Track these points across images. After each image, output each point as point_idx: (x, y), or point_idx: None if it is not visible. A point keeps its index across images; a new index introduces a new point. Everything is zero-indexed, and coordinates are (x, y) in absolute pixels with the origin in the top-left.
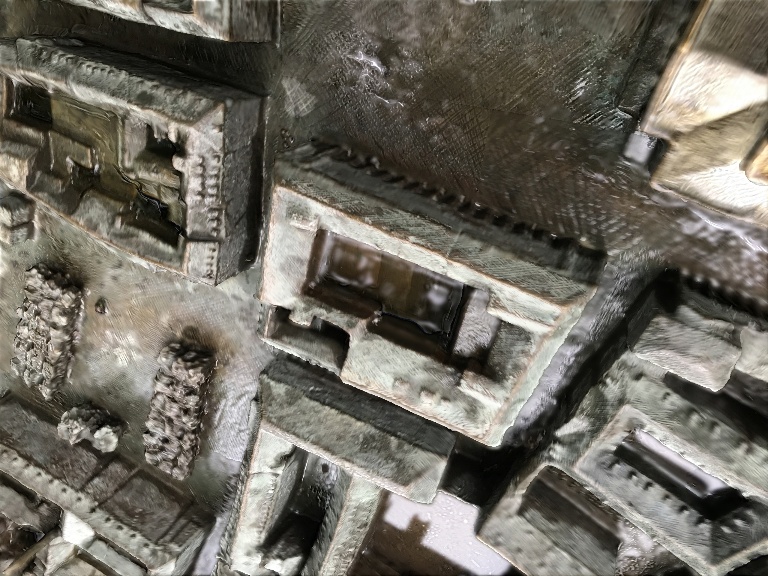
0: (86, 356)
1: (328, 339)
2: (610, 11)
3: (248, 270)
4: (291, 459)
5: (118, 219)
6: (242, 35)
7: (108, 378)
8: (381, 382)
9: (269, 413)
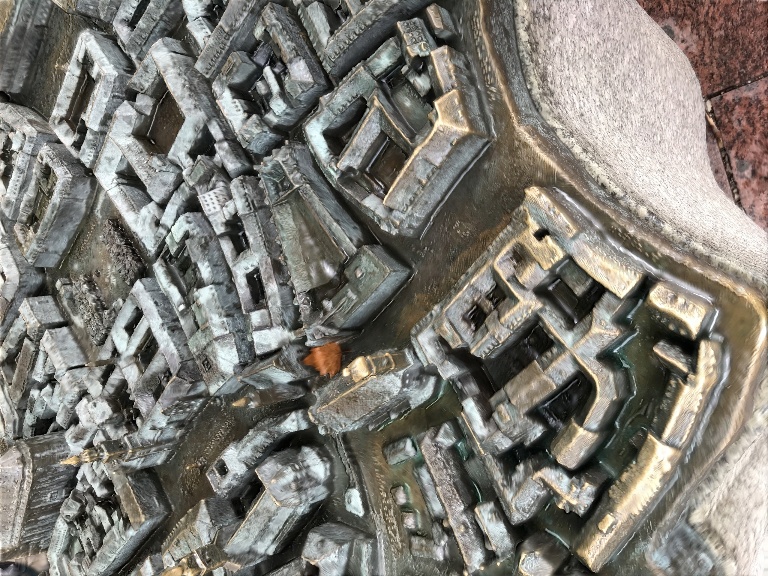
0: None
1: None
2: (81, 29)
3: None
4: (122, 179)
5: None
6: (44, 132)
7: None
8: None
9: None
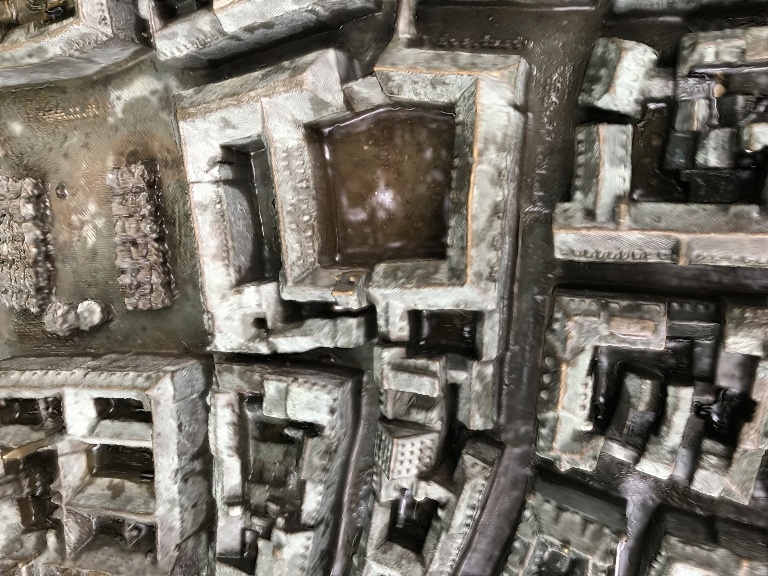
0: (63, 260)
1: (202, 7)
2: None
3: (153, 58)
4: (226, 169)
5: (31, 25)
6: None
7: (85, 269)
8: None
9: (182, 105)
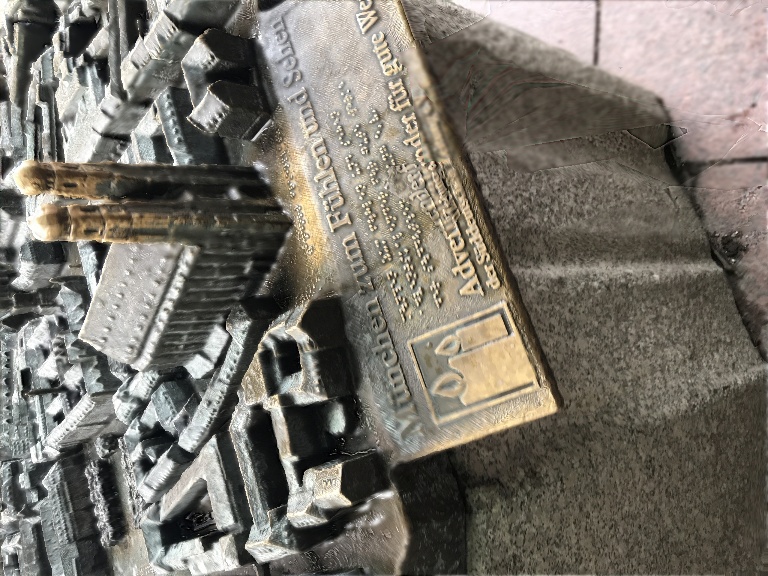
0: None
1: None
2: None
3: None
4: None
5: None
6: None
7: None
8: None
9: None
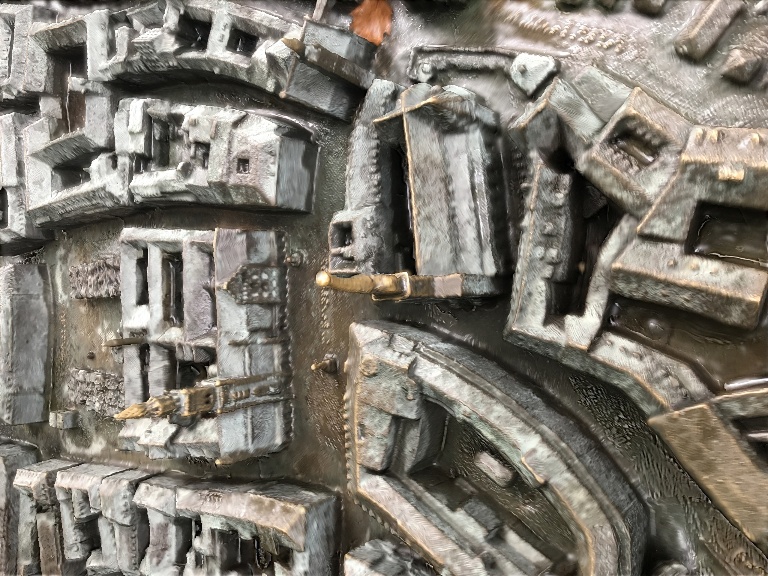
0: (121, 367)
1: None
2: None
3: None
4: None
5: None
6: None
7: None
8: (0, 169)
9: None
